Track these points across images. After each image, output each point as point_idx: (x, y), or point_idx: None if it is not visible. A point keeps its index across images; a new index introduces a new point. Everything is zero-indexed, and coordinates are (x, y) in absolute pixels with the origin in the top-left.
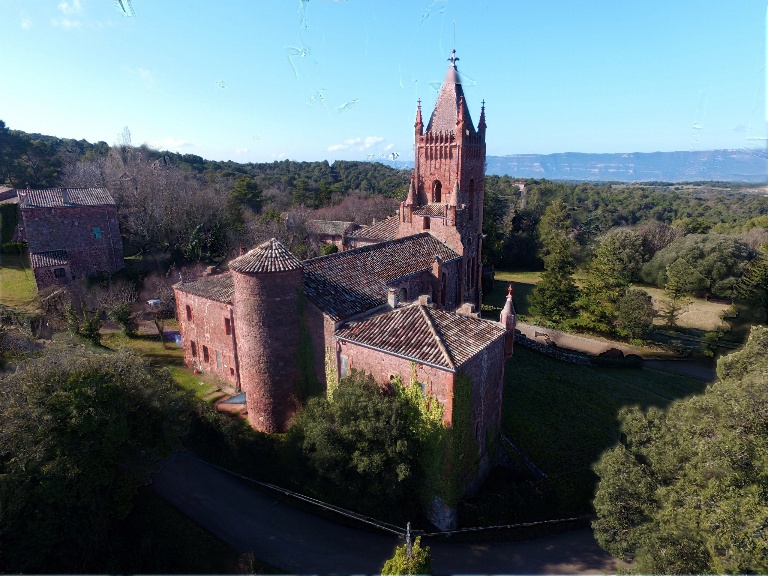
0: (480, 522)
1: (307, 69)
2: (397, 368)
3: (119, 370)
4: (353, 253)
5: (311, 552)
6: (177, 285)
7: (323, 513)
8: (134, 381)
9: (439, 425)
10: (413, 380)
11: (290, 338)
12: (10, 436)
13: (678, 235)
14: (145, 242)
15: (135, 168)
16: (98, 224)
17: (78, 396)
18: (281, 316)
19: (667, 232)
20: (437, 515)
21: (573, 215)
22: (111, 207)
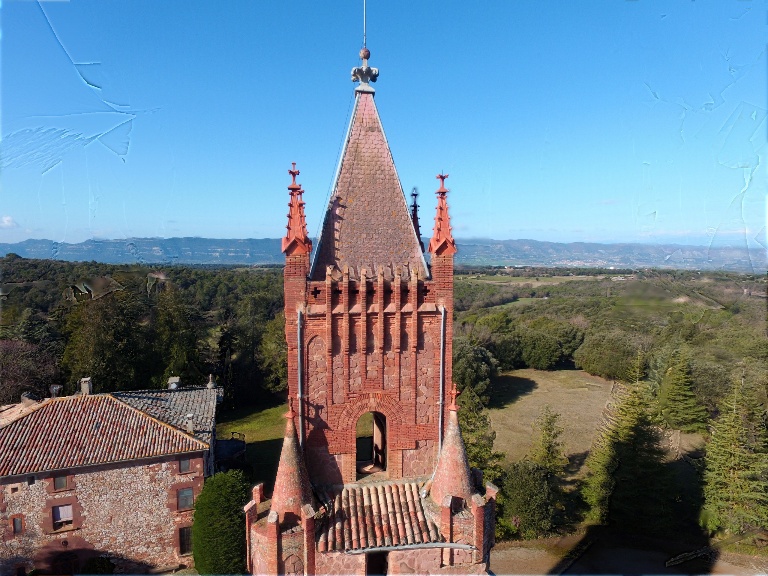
0: None
1: None
2: None
3: None
4: None
5: None
6: None
7: None
8: None
9: None
10: None
11: None
12: None
13: None
14: None
15: None
16: None
17: None
18: None
19: None
20: None
21: None
22: None
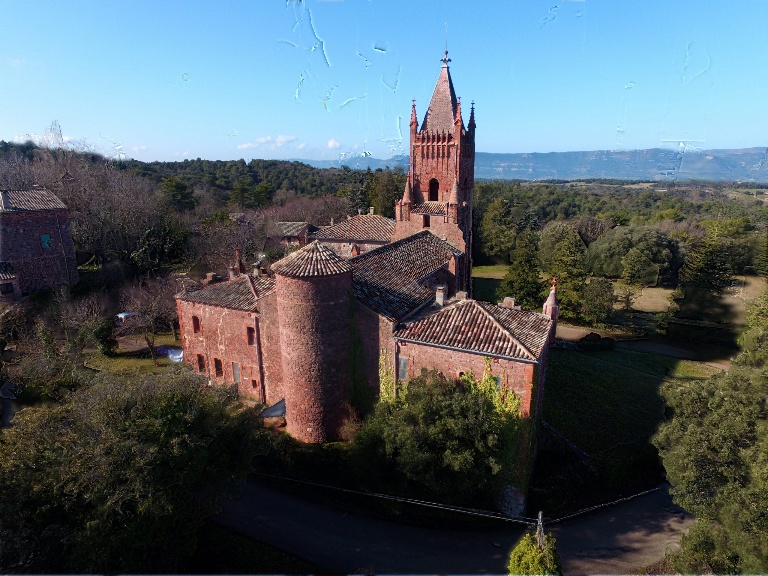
0: (548, 505)
1: (317, 64)
2: (468, 364)
3: (198, 390)
4: (377, 253)
5: (403, 558)
6: (180, 295)
7: (397, 518)
8: (219, 401)
9: (515, 416)
10: (487, 375)
11: (342, 343)
12: (98, 476)
13: (607, 227)
14: (105, 250)
15: (77, 167)
16: (47, 231)
17: (166, 423)
18: (334, 321)
19: (598, 225)
20: (509, 504)
21: (513, 211)
22: (62, 211)
